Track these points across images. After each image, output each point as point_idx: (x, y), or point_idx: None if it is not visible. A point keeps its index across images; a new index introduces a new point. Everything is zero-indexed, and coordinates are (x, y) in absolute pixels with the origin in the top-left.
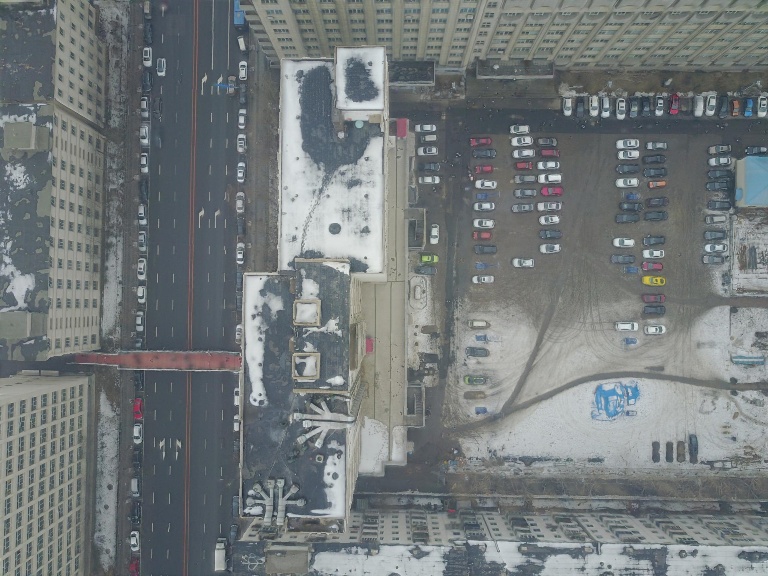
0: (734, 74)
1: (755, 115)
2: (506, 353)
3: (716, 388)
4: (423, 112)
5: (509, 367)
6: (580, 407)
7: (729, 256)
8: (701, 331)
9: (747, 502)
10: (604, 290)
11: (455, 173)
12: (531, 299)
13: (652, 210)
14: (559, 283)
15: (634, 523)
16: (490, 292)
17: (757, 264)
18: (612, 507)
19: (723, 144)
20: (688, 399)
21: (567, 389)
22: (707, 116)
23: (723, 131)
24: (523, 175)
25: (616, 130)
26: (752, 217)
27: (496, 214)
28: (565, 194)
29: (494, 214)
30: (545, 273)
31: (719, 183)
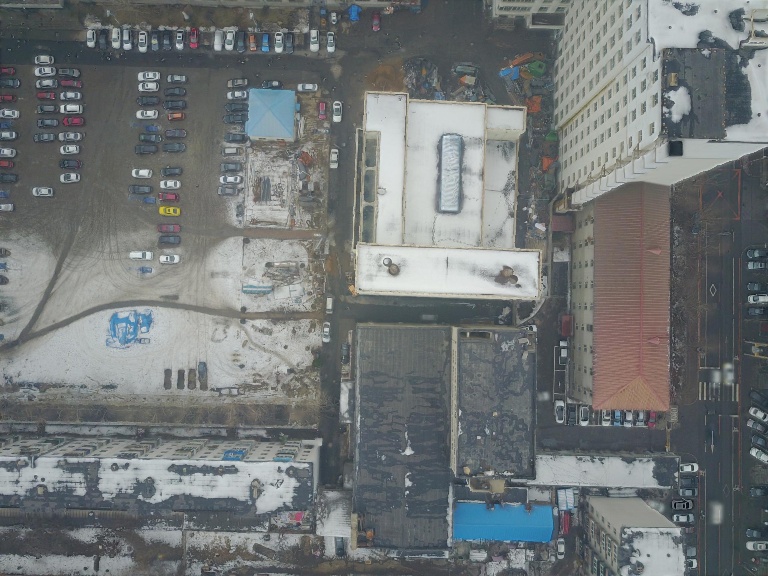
0: (256, 10)
1: (273, 50)
2: (25, 281)
3: (228, 317)
4: None
5: (28, 295)
6: (96, 335)
7: (244, 188)
8: (215, 261)
9: (252, 428)
10: (123, 220)
11: None
12: (51, 228)
13: (171, 142)
14: (79, 213)
15: (121, 445)
16: (11, 221)
17: (271, 196)
18: (122, 433)
19: (241, 78)
20: (201, 327)
21: (83, 317)
22: (228, 51)
23: (243, 66)
24: (43, 105)
25: (139, 63)
26: (268, 150)
27: (20, 144)
28: (88, 125)
29: (18, 144)
30: (66, 202)
31: (233, 116)
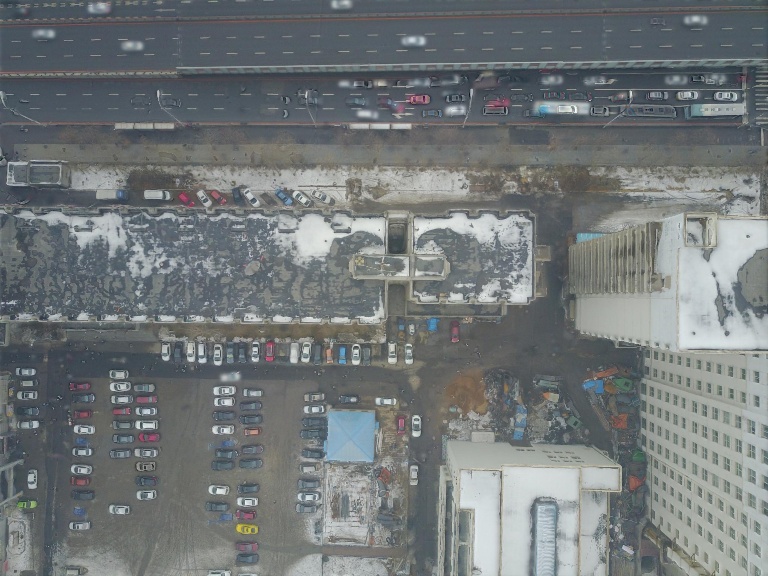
0: None
1: (350, 362)
2: None
3: None
4: (25, 354)
5: None
6: None
7: (322, 504)
8: None
9: None
10: (200, 537)
11: (56, 416)
12: (128, 545)
13: (248, 457)
14: (156, 529)
15: None
16: (88, 537)
17: (350, 512)
18: None
19: (318, 391)
20: None
21: None
22: (304, 362)
23: (320, 377)
24: (119, 422)
25: (215, 375)
26: (346, 465)
27: (96, 458)
28: (164, 439)
29: (94, 458)
30: (142, 519)
31: (311, 432)
